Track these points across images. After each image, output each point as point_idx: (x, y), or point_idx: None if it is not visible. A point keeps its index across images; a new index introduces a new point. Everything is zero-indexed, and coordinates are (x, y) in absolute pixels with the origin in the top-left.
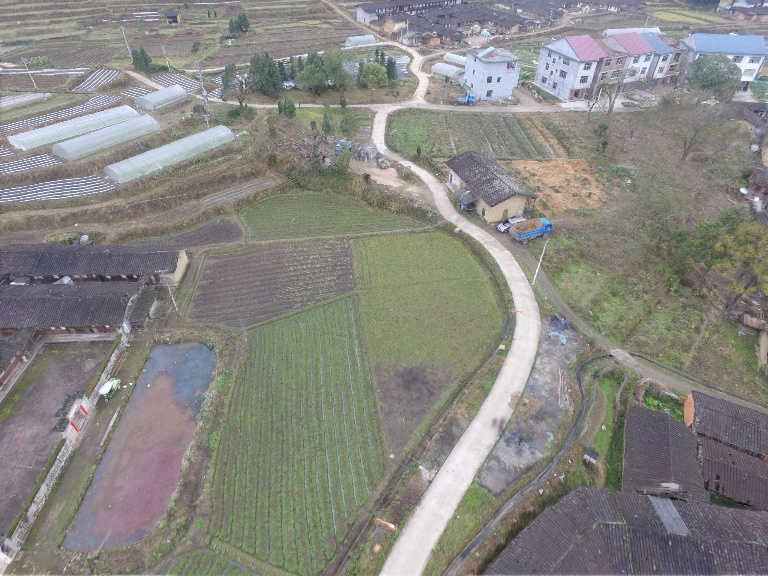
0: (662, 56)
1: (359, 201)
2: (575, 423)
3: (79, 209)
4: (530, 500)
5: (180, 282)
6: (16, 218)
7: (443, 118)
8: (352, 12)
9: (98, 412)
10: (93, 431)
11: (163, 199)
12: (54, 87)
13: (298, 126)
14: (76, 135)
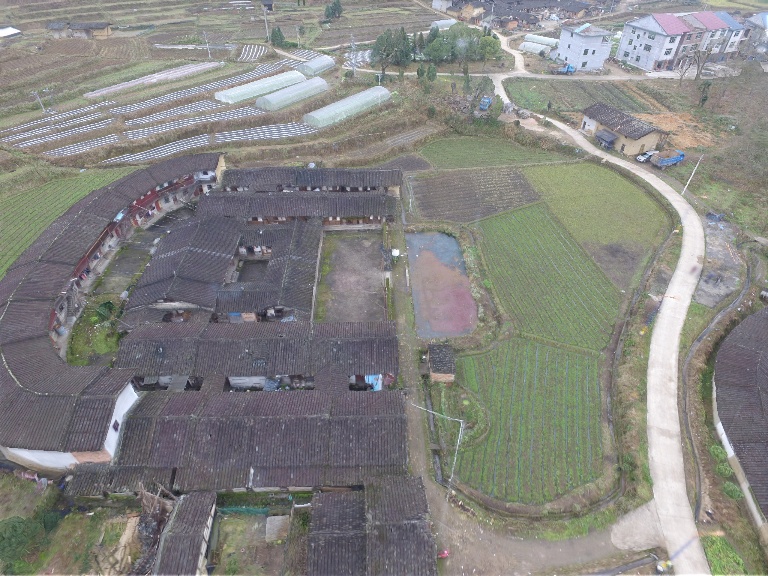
0: (735, 32)
1: (512, 142)
2: (747, 276)
3: (298, 145)
4: (733, 313)
5: (400, 195)
6: (253, 151)
7: (549, 84)
8: (426, 0)
9: (393, 269)
10: (397, 279)
11: (358, 139)
12: (224, 57)
13: (437, 88)
14: (264, 93)
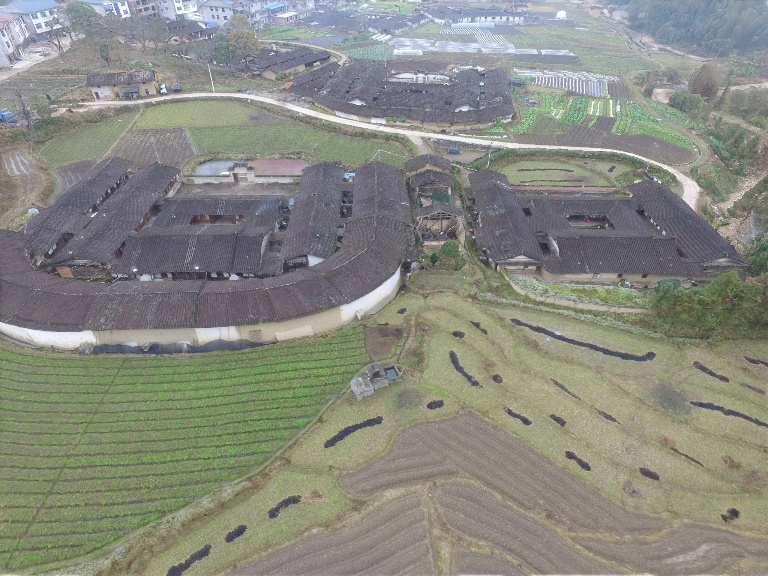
0: (19, 20)
1: (88, 124)
2: None
3: None
4: None
5: None
6: None
7: None
8: None
9: None
10: None
11: (3, 181)
12: None
13: None
14: None
